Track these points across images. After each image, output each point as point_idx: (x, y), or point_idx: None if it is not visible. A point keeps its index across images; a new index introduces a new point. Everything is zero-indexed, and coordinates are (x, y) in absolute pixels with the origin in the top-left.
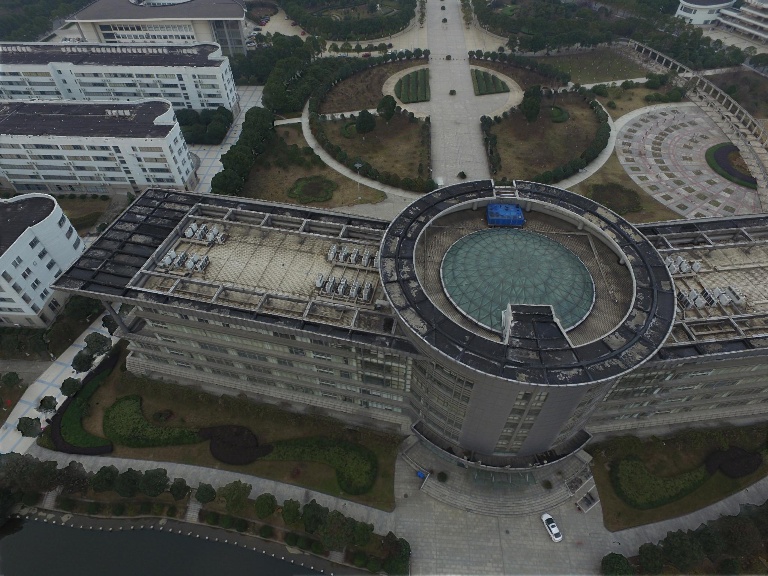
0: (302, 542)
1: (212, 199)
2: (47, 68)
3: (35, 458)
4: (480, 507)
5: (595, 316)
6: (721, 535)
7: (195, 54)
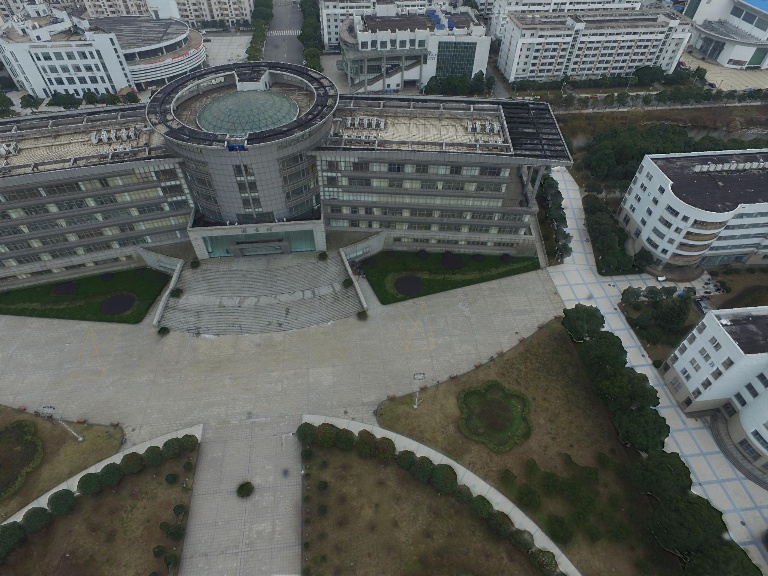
0: None
1: None
2: None
3: None
4: None
5: None
6: None
7: None
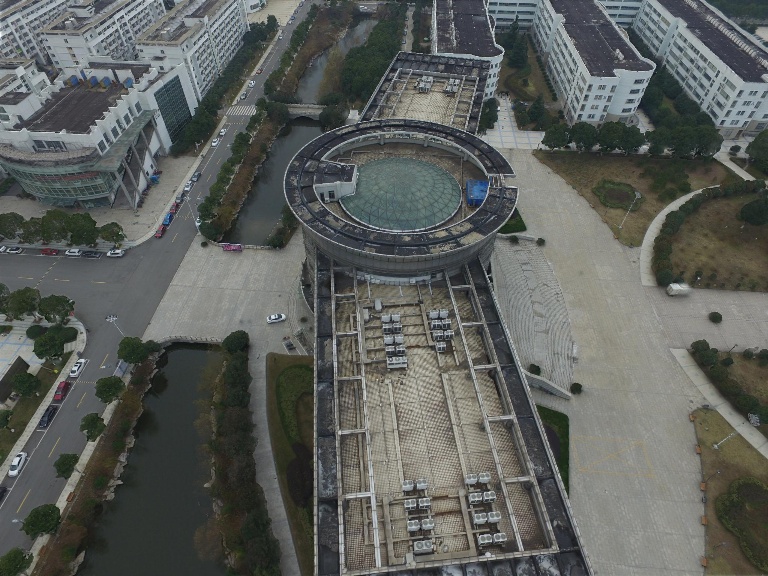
0: None
1: None
2: (673, 20)
3: None
4: (297, 282)
5: None
6: (237, 403)
7: (767, 69)
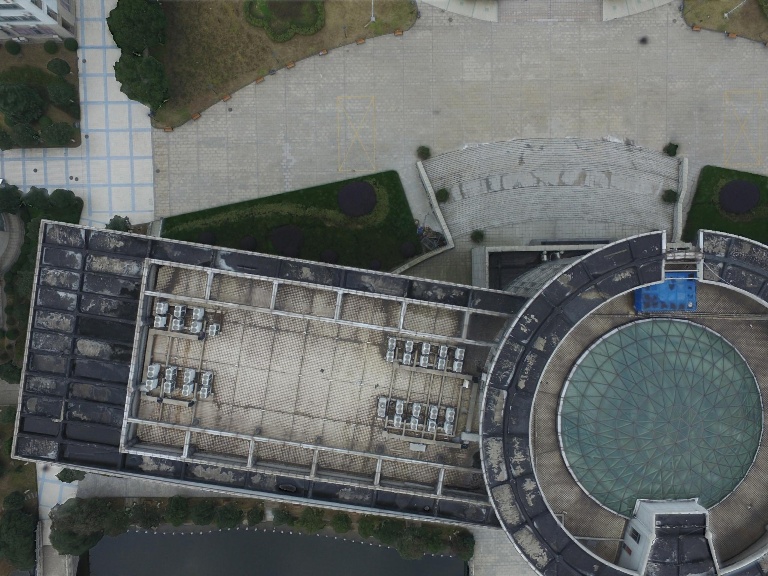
0: (378, 537)
1: (168, 242)
2: None
3: (97, 502)
4: None
5: (748, 477)
6: None
7: None
